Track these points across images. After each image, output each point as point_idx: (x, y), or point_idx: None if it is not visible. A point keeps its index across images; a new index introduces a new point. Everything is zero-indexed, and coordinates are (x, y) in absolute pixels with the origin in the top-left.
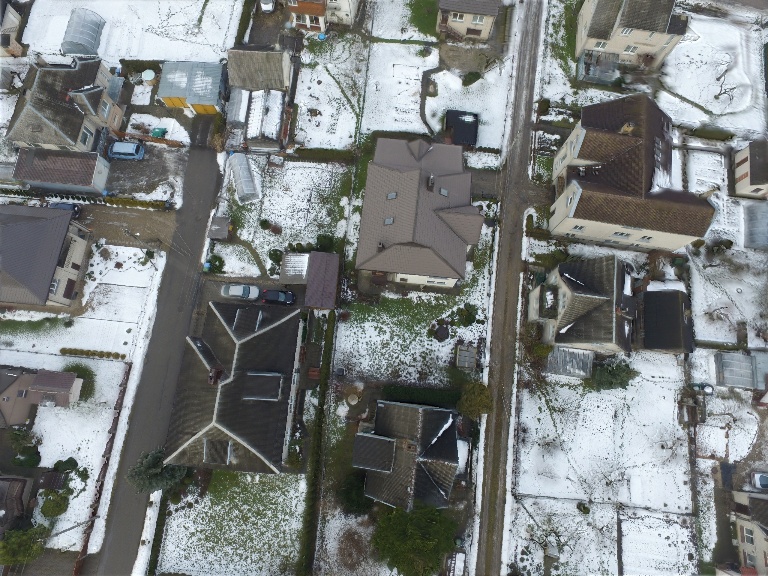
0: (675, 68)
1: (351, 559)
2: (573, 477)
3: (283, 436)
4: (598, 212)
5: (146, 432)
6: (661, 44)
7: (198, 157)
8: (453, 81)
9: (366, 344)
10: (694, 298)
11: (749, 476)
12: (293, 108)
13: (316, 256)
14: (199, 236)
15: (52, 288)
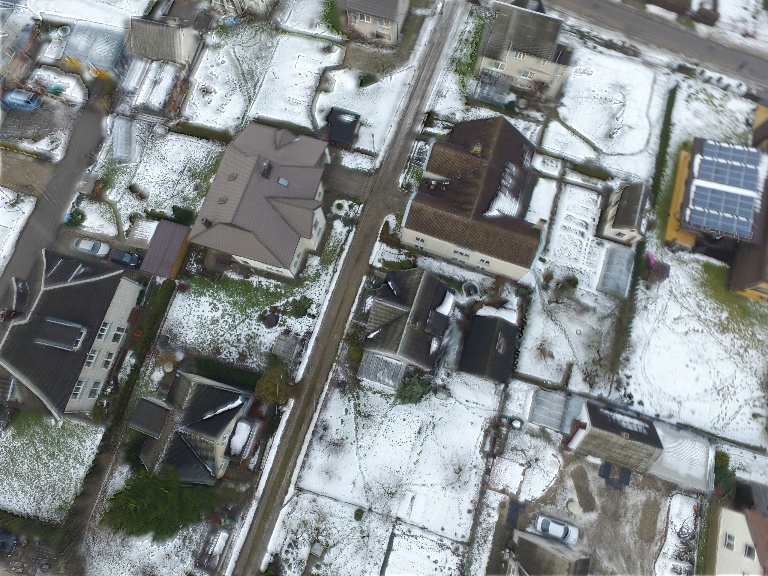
0: (576, 101)
1: None
2: (359, 483)
3: (73, 386)
4: (428, 226)
5: None
6: (555, 73)
7: (91, 115)
8: (351, 80)
9: (197, 317)
10: (530, 331)
11: (535, 517)
12: (191, 82)
13: (165, 224)
14: (71, 188)
15: None
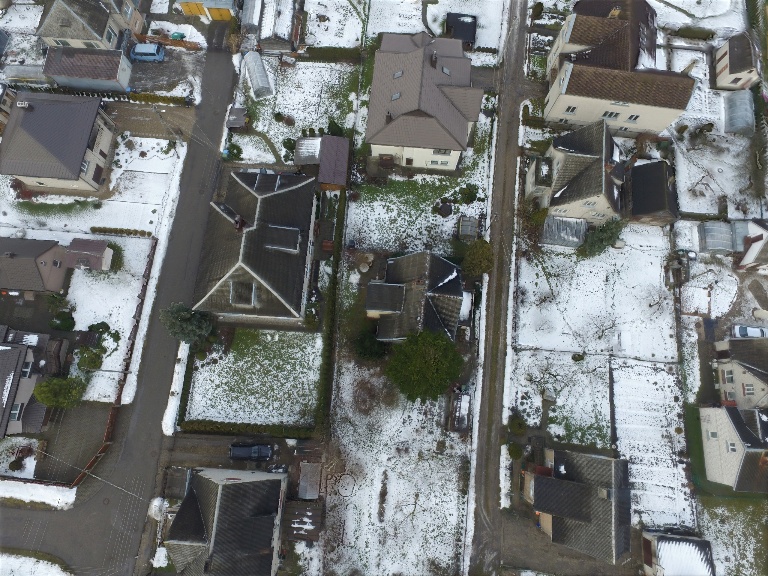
0: None
1: (365, 405)
2: (568, 332)
3: (302, 285)
4: (588, 87)
5: (172, 299)
6: None
7: (215, 59)
8: None
9: (375, 220)
10: (678, 177)
11: (730, 329)
12: (303, 15)
13: (328, 139)
14: (217, 128)
15: (83, 168)
